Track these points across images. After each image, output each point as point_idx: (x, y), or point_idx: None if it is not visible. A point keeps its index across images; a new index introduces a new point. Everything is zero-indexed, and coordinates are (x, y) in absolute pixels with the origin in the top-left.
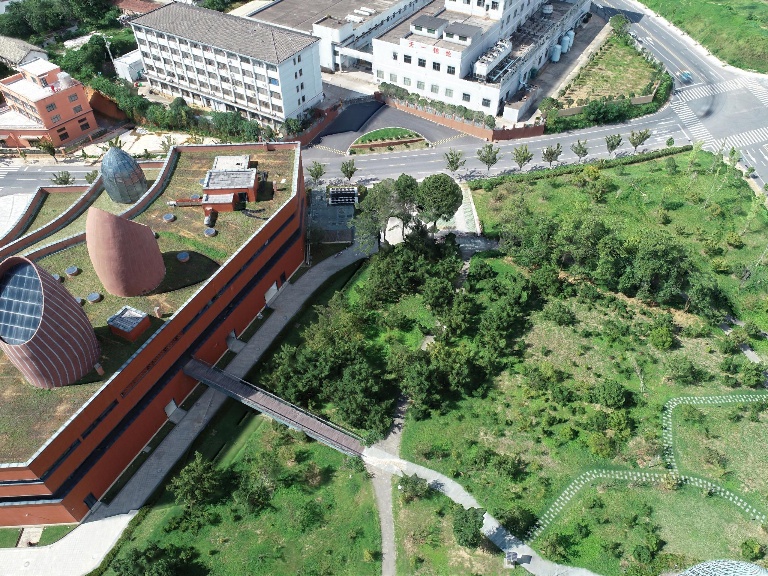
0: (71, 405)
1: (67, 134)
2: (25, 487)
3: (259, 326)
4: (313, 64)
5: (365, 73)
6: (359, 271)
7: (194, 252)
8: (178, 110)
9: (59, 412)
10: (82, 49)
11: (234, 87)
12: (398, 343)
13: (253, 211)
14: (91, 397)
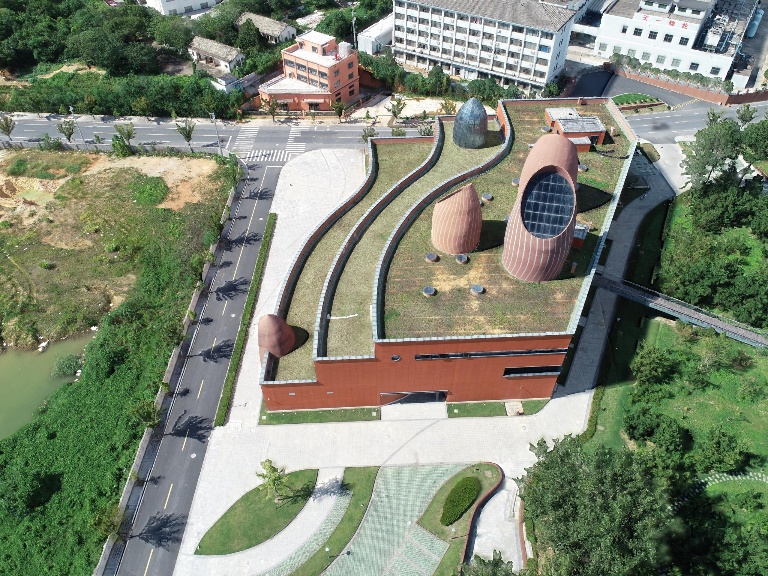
0: (565, 294)
1: (340, 99)
2: (549, 357)
3: (607, 253)
4: (568, 35)
5: (580, 47)
6: (670, 210)
7: (579, 183)
8: (438, 77)
9: (559, 299)
10: (326, 25)
11: (495, 56)
12: (759, 261)
13: (605, 152)
14: (587, 286)
